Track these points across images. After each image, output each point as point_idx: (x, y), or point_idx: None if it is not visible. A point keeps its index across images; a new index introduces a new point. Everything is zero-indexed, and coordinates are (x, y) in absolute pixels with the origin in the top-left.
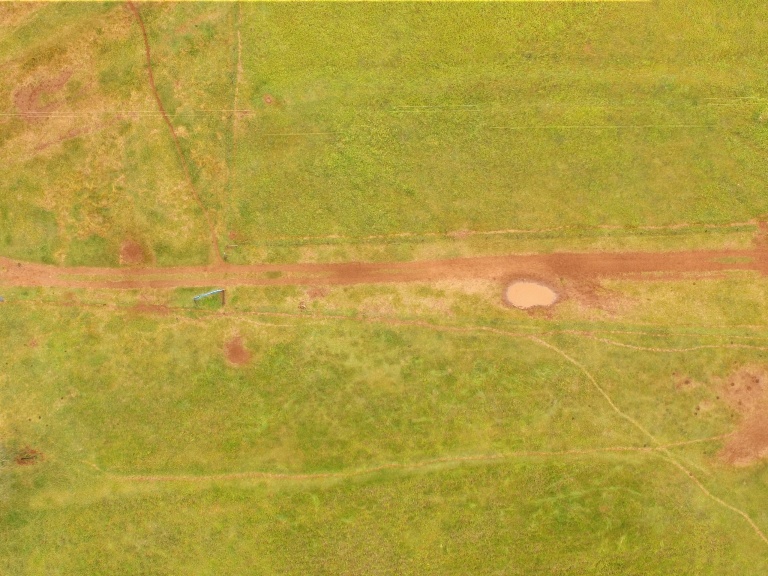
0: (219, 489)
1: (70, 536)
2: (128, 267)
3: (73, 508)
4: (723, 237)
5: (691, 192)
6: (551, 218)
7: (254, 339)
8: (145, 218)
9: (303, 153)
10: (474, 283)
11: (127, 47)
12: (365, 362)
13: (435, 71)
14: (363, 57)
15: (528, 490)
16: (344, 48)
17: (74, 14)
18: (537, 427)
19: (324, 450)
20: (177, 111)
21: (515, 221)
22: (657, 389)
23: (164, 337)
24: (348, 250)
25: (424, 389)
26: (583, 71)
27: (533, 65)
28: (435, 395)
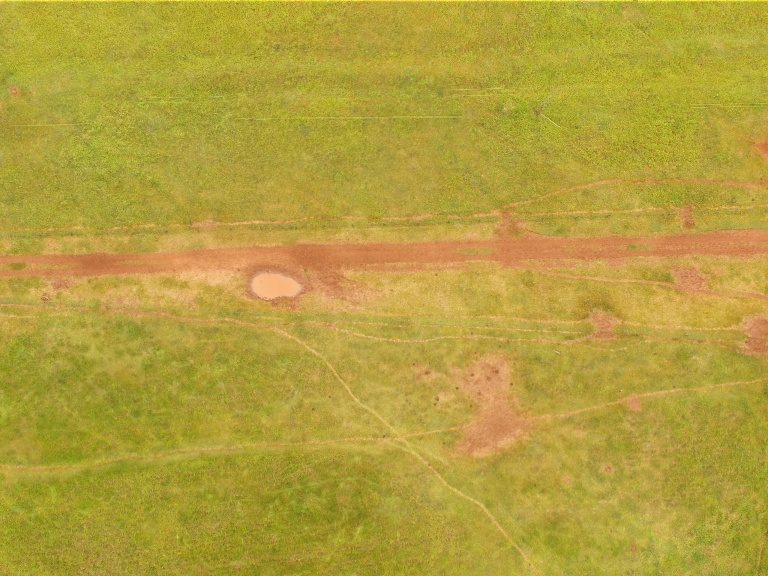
0: None
1: None
2: None
3: None
4: (466, 228)
5: (435, 183)
6: (296, 209)
7: None
8: None
9: (50, 144)
10: (218, 274)
11: None
12: (106, 353)
13: (182, 62)
14: (111, 48)
15: (265, 481)
16: (92, 39)
17: None
18: (277, 418)
19: (63, 441)
20: None
21: (260, 212)
22: (397, 380)
23: None
24: (92, 241)
25: (165, 380)
26: (330, 62)
27: (281, 56)
28: (175, 386)
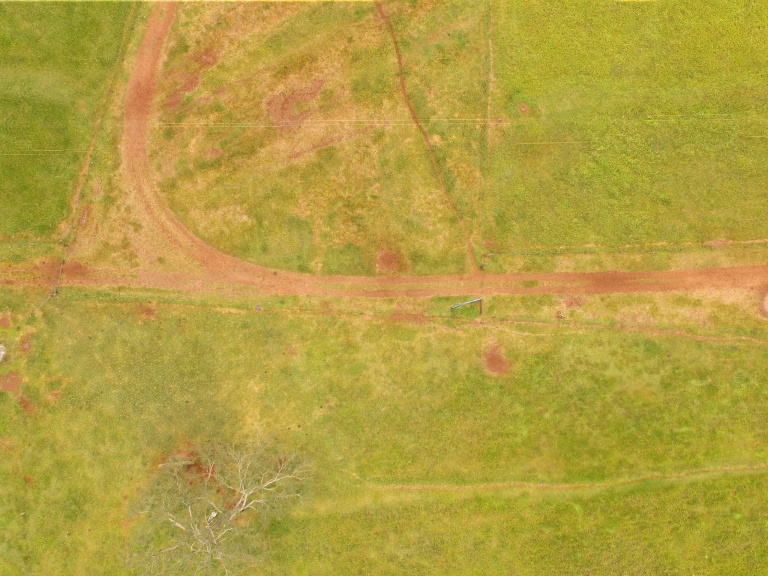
0: (481, 499)
1: (333, 545)
2: (384, 276)
3: (335, 517)
4: None
5: None
6: None
7: (512, 348)
8: (401, 227)
9: (557, 162)
10: (732, 293)
11: (378, 56)
12: (625, 372)
13: (689, 80)
14: (616, 66)
15: None
16: (597, 57)
17: (325, 22)
18: None
19: (585, 460)
20: (431, 120)
21: None
22: None
23: (422, 346)
24: (605, 259)
25: (685, 399)
26: None
27: None
28: (696, 405)
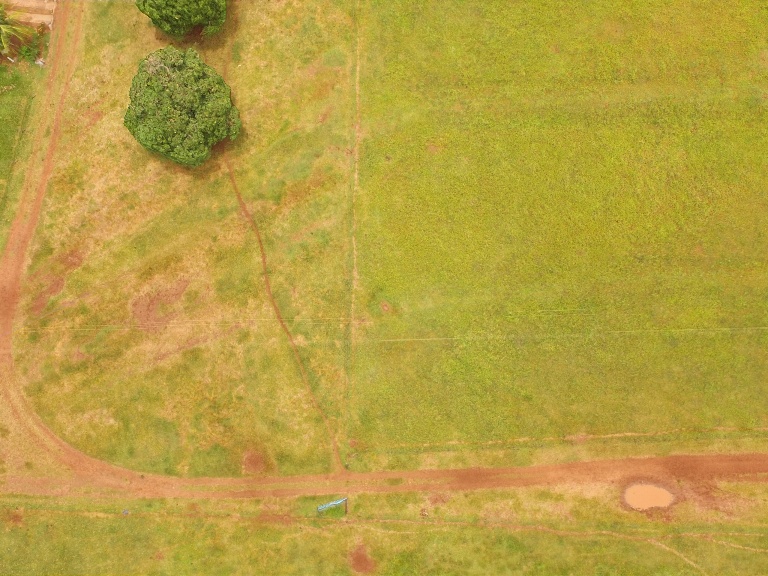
0: None
1: None
2: (250, 477)
3: None
4: None
5: None
6: (667, 421)
7: (378, 547)
8: (266, 428)
9: (420, 359)
10: (593, 487)
11: (243, 254)
12: (488, 569)
13: (549, 275)
14: (478, 262)
15: None
16: (459, 253)
17: (189, 222)
18: None
19: None
20: (295, 320)
21: (632, 424)
22: None
23: (288, 547)
24: (468, 456)
25: None
26: (695, 273)
27: (646, 267)
28: None
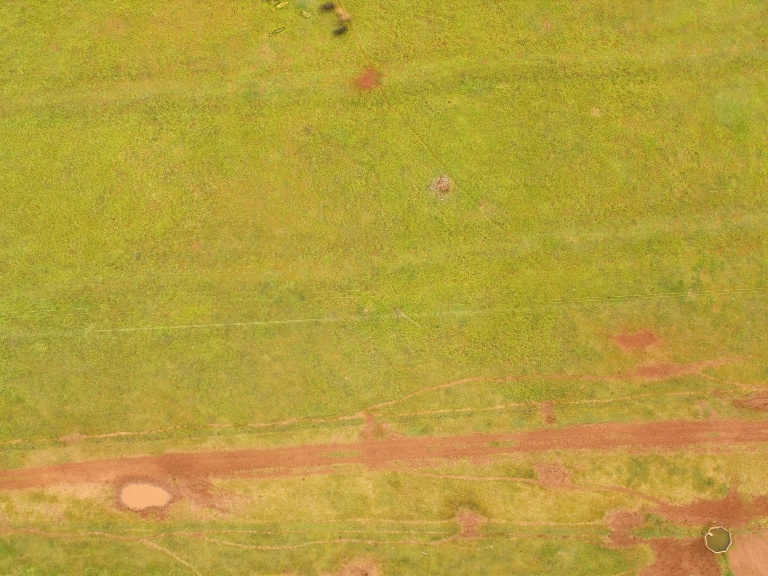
0: None
1: None
2: None
3: None
4: (331, 431)
5: (300, 387)
6: (162, 419)
7: None
8: None
9: None
10: (86, 488)
11: None
12: None
13: (44, 275)
14: None
15: None
16: None
17: None
18: None
19: None
20: None
21: (126, 423)
22: None
23: None
24: None
25: None
26: (191, 269)
27: (142, 265)
28: None
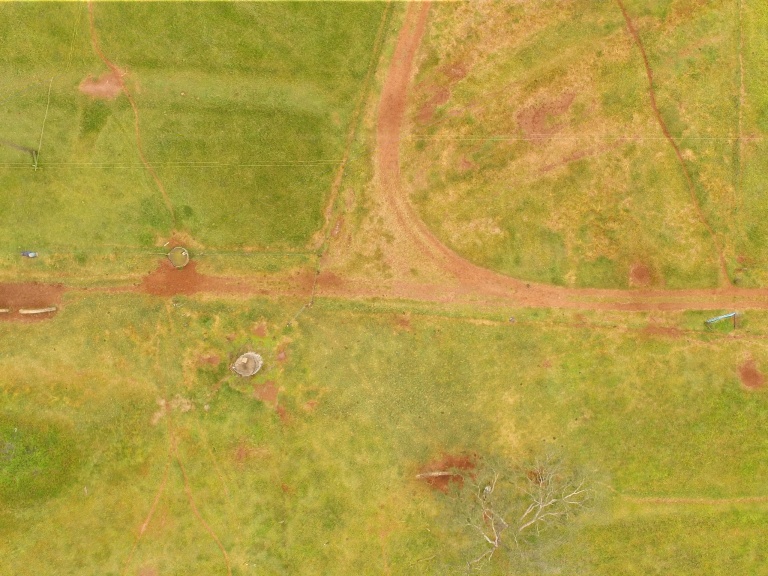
0: (739, 512)
1: (590, 557)
2: (636, 289)
3: (591, 529)
4: None
5: None
6: None
7: (767, 363)
8: (653, 241)
9: None
10: None
11: (627, 70)
12: None
13: None
14: None
15: None
16: None
17: (574, 36)
18: None
19: None
20: (684, 134)
21: None
22: None
23: (676, 360)
24: None
25: None
26: None
27: None
28: None
